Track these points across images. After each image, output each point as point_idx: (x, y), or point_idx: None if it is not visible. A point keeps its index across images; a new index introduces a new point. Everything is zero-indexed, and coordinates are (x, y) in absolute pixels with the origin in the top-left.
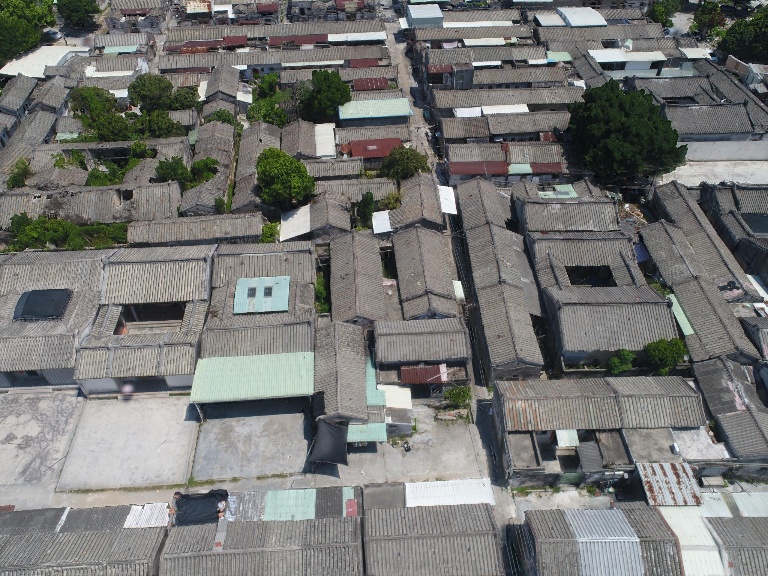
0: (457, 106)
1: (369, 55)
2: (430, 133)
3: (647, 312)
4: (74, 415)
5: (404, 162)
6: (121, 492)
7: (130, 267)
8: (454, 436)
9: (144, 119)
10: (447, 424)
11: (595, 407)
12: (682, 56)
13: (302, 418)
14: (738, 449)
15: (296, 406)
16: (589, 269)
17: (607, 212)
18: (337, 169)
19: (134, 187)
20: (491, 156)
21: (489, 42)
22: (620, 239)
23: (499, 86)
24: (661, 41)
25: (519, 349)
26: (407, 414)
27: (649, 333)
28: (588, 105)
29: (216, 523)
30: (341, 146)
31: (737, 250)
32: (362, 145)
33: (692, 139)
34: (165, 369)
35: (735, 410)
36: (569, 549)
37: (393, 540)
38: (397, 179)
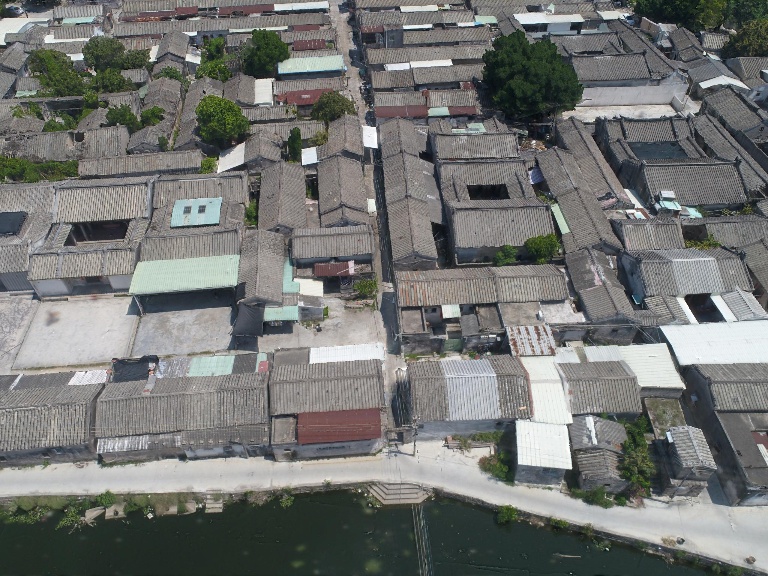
0: (387, 62)
1: (311, 21)
2: (363, 87)
3: (529, 215)
4: (29, 313)
5: (331, 104)
6: (69, 368)
7: (79, 192)
8: (360, 320)
9: (98, 77)
10: (355, 311)
11: (476, 286)
12: (598, 18)
13: (230, 310)
14: (592, 314)
15: (225, 301)
16: (491, 190)
17: (508, 142)
18: (272, 114)
19: (85, 130)
20: (413, 101)
21: (423, 9)
22: (516, 162)
23: (429, 46)
24: (581, 5)
25: (416, 246)
26: (318, 300)
27: (530, 232)
28: (496, 52)
29: (147, 379)
30: (278, 96)
31: (621, 171)
32: (297, 94)
33: (597, 86)
34: (108, 270)
35: (593, 286)
36: (438, 384)
37: (293, 383)
38: (326, 121)
